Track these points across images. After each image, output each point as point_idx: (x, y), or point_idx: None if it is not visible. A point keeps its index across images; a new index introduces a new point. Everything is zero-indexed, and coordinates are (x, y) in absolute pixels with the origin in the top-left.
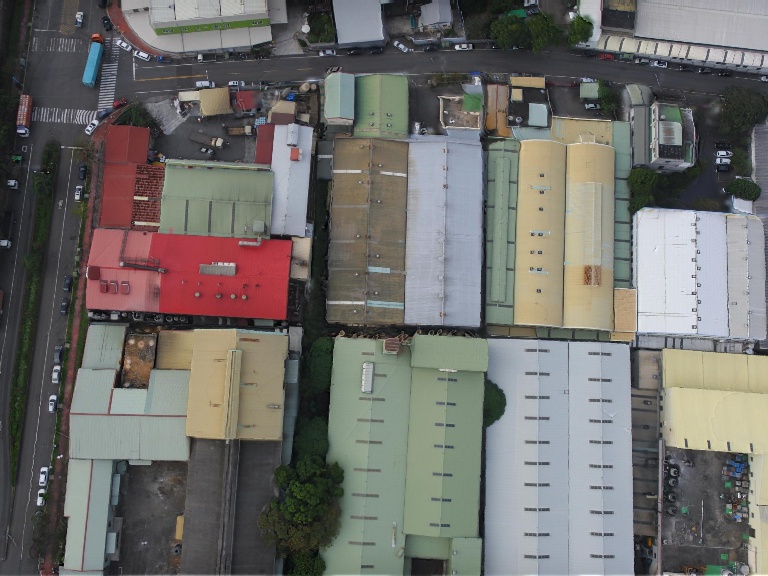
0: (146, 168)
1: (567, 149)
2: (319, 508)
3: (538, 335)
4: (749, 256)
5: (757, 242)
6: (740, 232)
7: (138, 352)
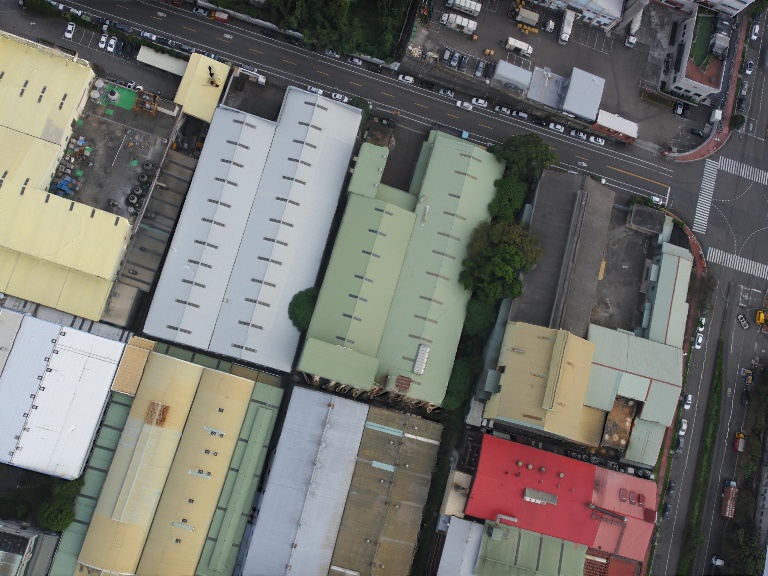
0: None
1: (136, 570)
2: (491, 254)
3: (230, 366)
4: None
5: None
6: None
7: (619, 431)
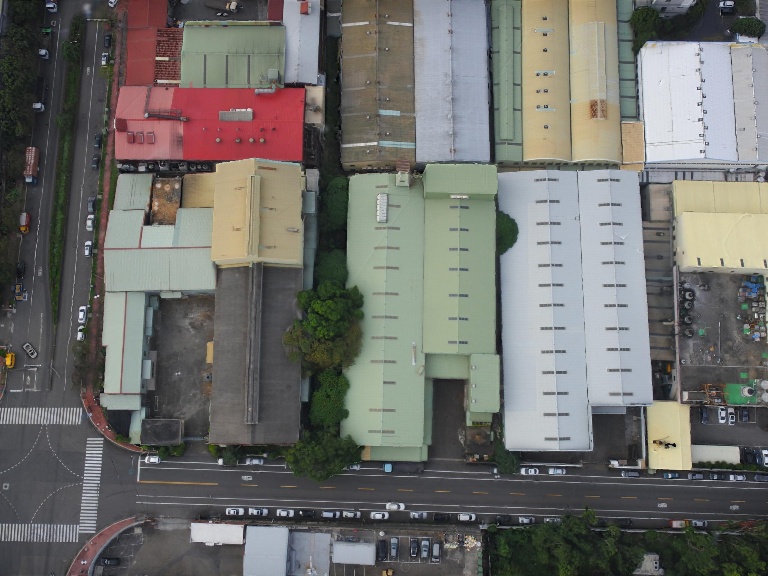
0: (166, 31)
1: None
2: (340, 324)
3: None
4: (755, 83)
5: (762, 70)
6: (745, 61)
7: (165, 195)
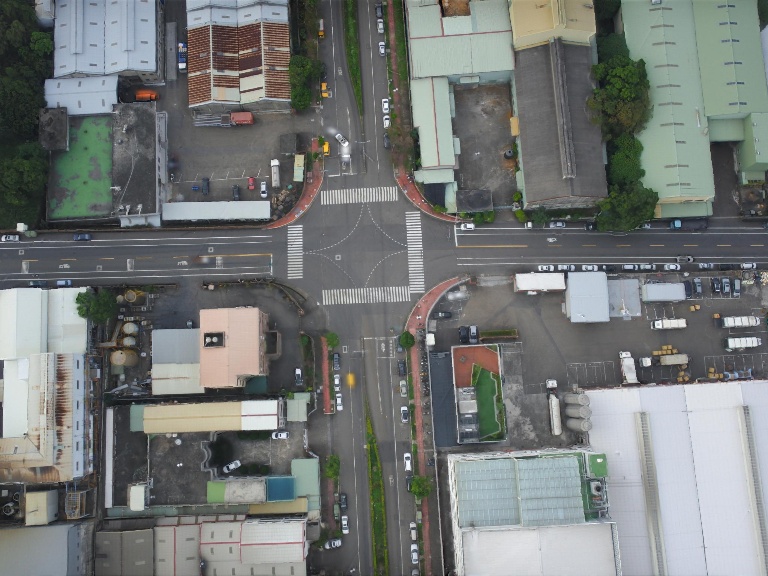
0: None
1: None
2: (638, 88)
3: None
4: None
5: None
6: None
7: None
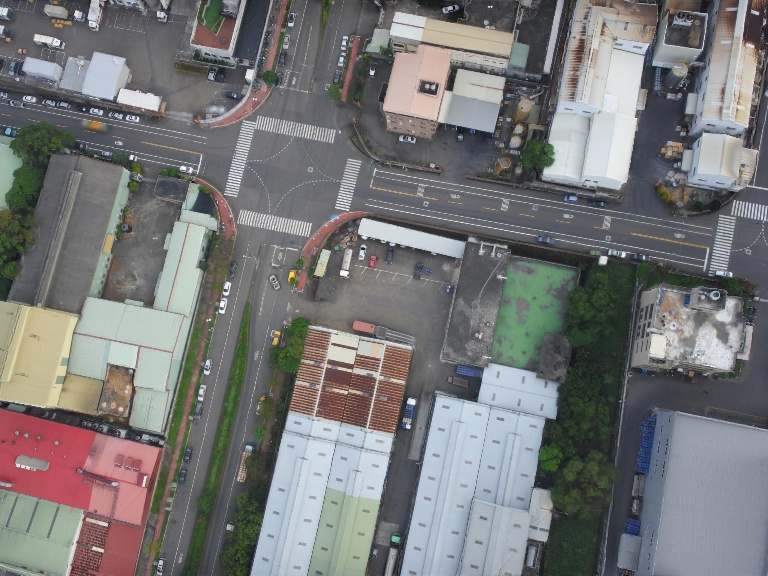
0: None
1: None
2: None
3: None
4: None
5: None
6: None
7: (117, 399)
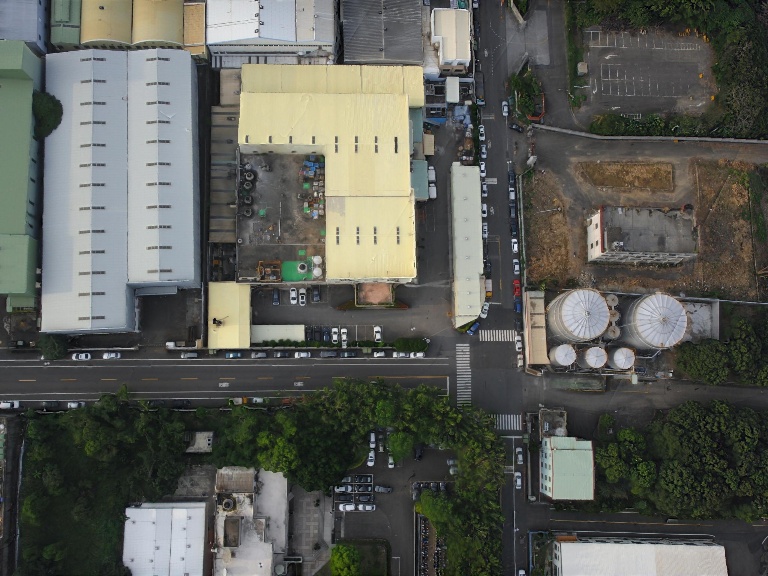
0: None
1: None
2: None
3: None
4: None
5: None
6: None
7: None
